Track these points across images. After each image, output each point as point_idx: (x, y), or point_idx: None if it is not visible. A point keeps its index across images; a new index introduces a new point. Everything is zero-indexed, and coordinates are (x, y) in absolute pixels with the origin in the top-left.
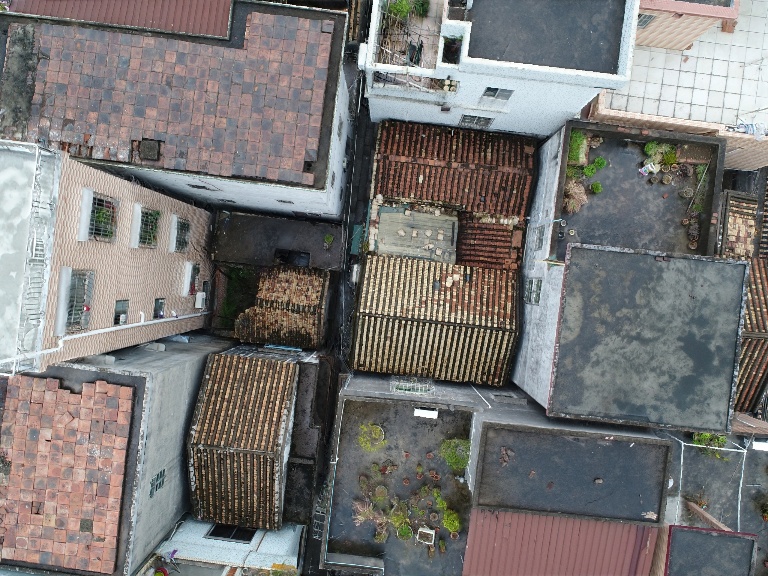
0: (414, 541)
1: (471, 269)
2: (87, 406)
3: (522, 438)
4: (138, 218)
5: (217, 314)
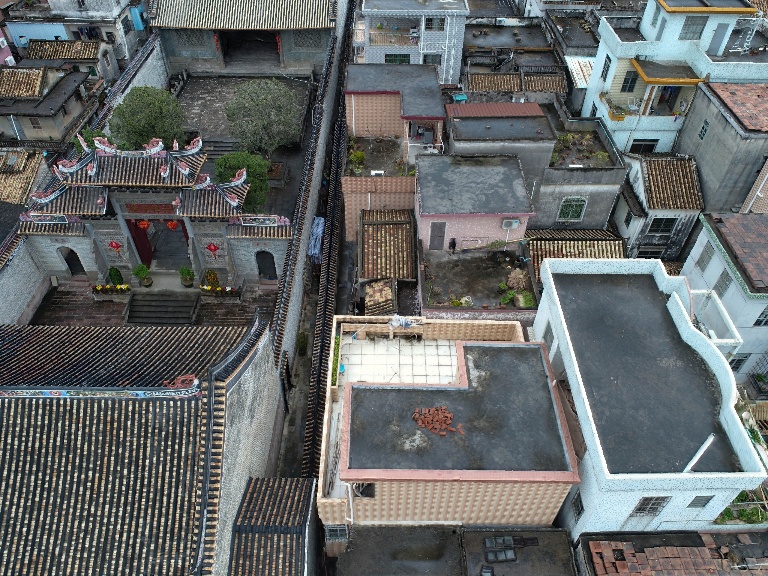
0: None
1: None
2: (766, 123)
3: None
4: None
5: None
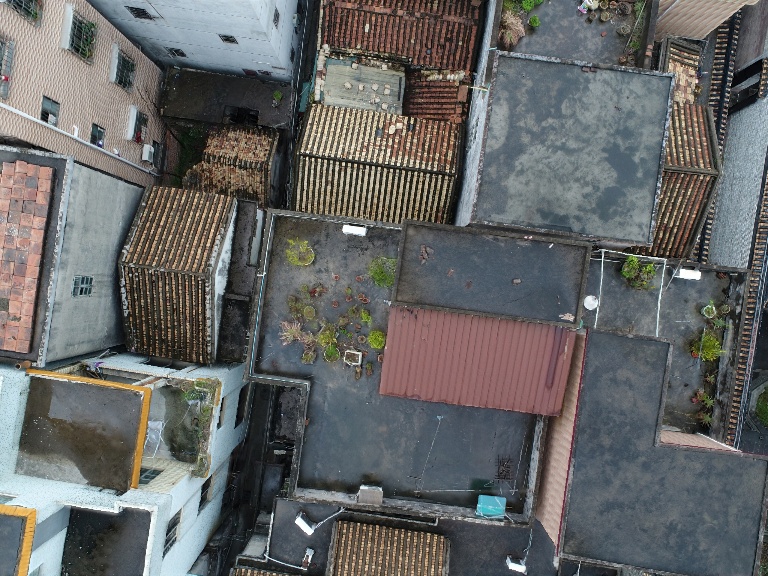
0: (342, 364)
1: (415, 119)
2: (6, 185)
3: (442, 236)
4: (69, 18)
5: (167, 177)
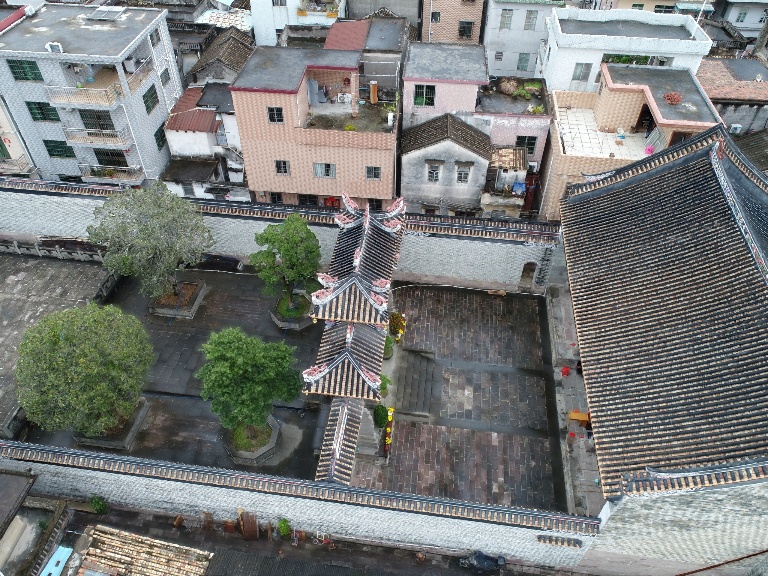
0: None
1: None
2: None
3: (401, 25)
4: None
5: None
